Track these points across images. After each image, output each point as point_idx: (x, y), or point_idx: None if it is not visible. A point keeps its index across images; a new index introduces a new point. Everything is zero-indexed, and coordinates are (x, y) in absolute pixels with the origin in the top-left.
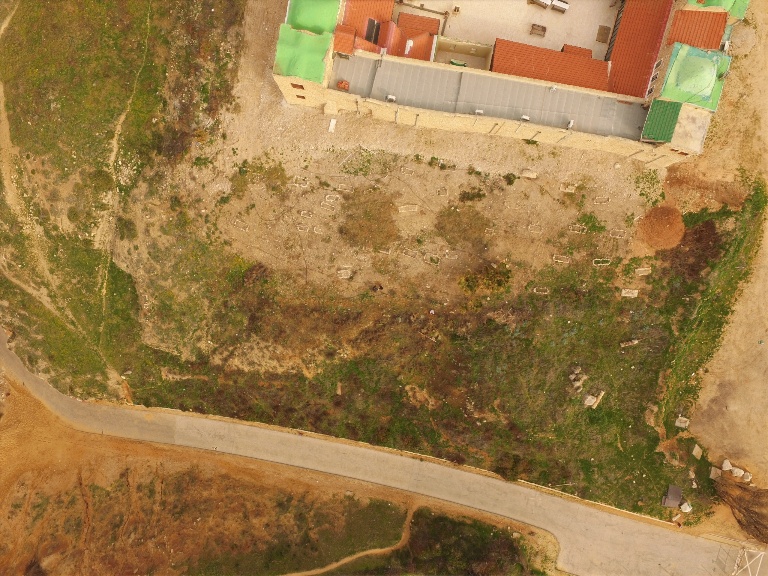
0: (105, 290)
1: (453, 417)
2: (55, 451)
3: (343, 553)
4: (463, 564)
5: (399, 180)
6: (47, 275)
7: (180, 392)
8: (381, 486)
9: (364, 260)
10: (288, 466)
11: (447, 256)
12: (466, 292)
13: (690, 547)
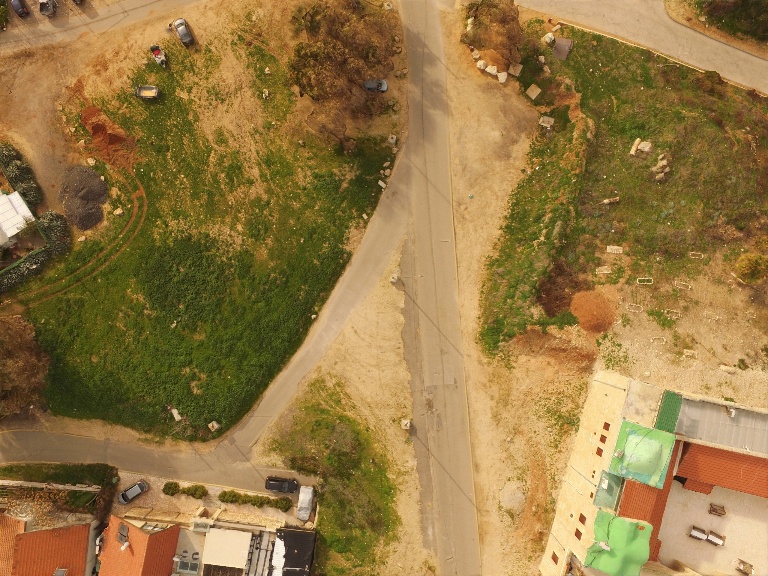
0: None
1: None
2: None
3: None
4: None
5: None
6: None
7: None
8: None
9: None
10: None
11: None
12: None
13: None
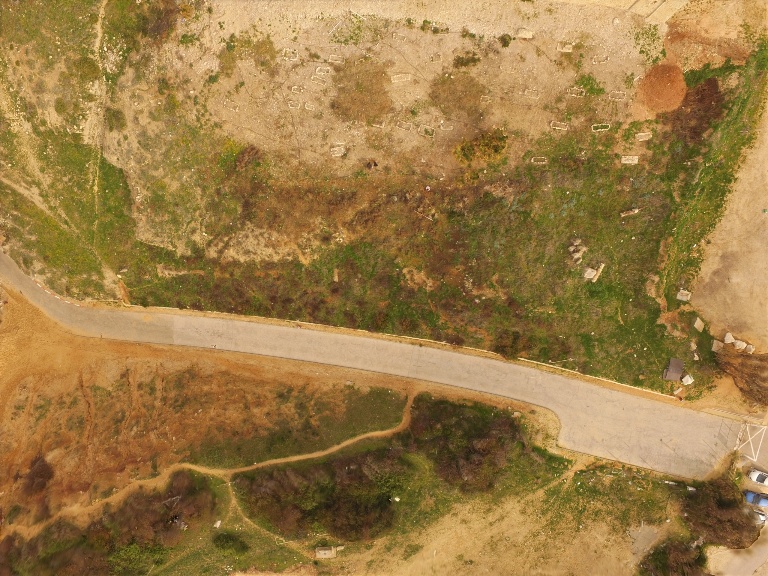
0: (97, 187)
1: (451, 296)
2: (55, 356)
3: (344, 436)
4: (464, 441)
5: (391, 47)
6: (38, 174)
7: (177, 289)
8: (381, 374)
9: (357, 135)
10: (287, 360)
11: (442, 127)
12: (462, 162)
13: (692, 422)
